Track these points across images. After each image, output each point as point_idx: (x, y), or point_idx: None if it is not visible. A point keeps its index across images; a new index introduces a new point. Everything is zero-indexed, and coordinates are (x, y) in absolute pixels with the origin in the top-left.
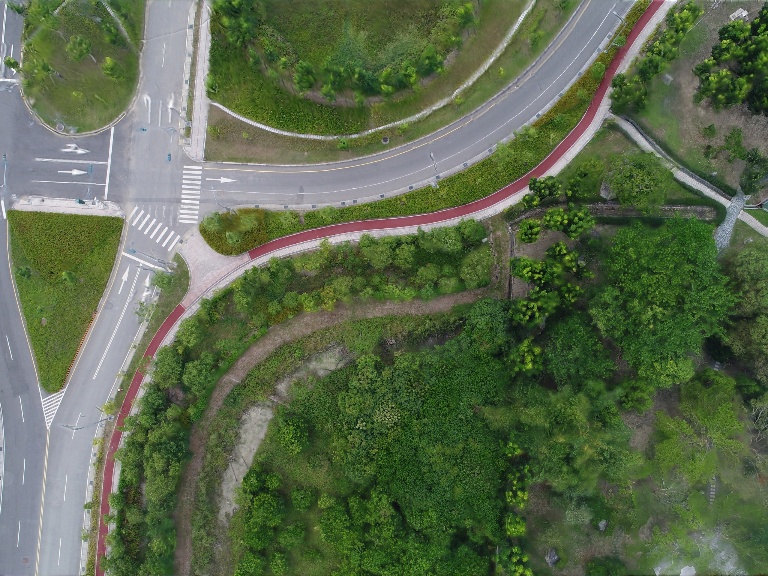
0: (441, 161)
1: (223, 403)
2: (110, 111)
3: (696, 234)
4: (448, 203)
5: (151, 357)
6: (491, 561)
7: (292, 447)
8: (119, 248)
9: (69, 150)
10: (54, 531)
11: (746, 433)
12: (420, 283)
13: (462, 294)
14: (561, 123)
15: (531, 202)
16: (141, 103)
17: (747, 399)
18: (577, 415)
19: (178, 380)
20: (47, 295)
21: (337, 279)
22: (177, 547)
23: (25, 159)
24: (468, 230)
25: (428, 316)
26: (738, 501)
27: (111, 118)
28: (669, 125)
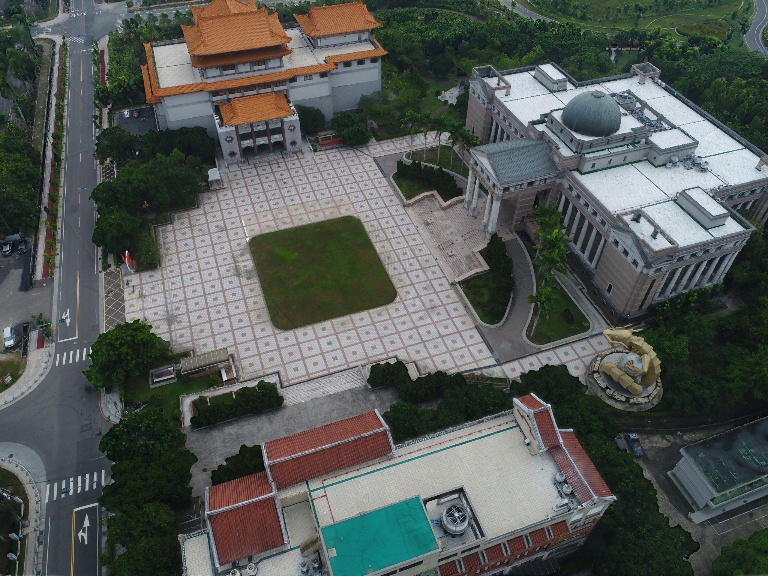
0: None
1: (427, 9)
2: None
3: None
4: None
5: None
6: None
7: None
8: None
9: None
10: None
11: None
12: None
13: None
14: None
15: None
16: None
17: None
18: None
19: None
20: None
21: None
22: None
23: None
24: None
25: None
26: None
27: None
28: None
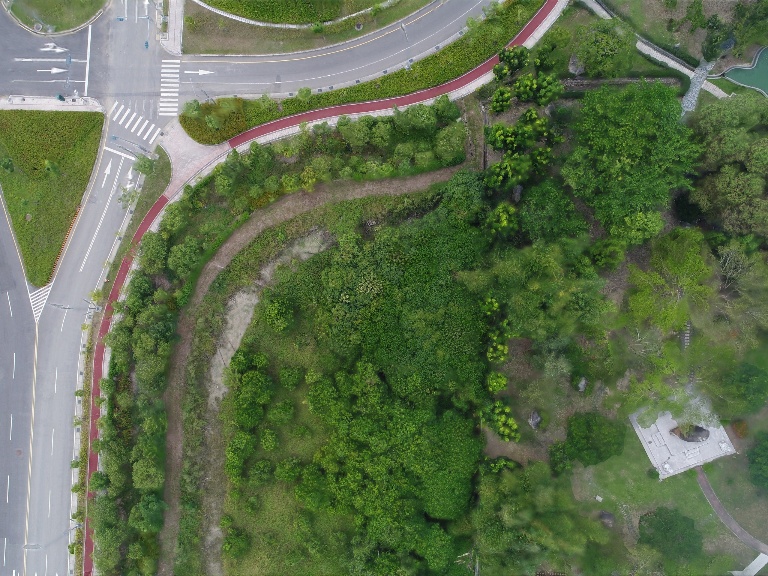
0: (414, 45)
1: (209, 289)
2: (87, 9)
3: (661, 95)
4: (422, 84)
5: None
6: (476, 428)
7: (278, 323)
8: (101, 143)
9: (48, 49)
10: (46, 422)
11: (715, 280)
12: (397, 159)
13: (439, 173)
14: (528, 0)
15: (501, 71)
16: (117, 0)
17: (715, 247)
18: (551, 262)
19: (163, 265)
20: (31, 191)
21: (316, 158)
22: (169, 432)
23: (4, 60)
24: (442, 105)
25: (406, 195)
26: (709, 344)
27: (88, 16)
28: (633, 1)
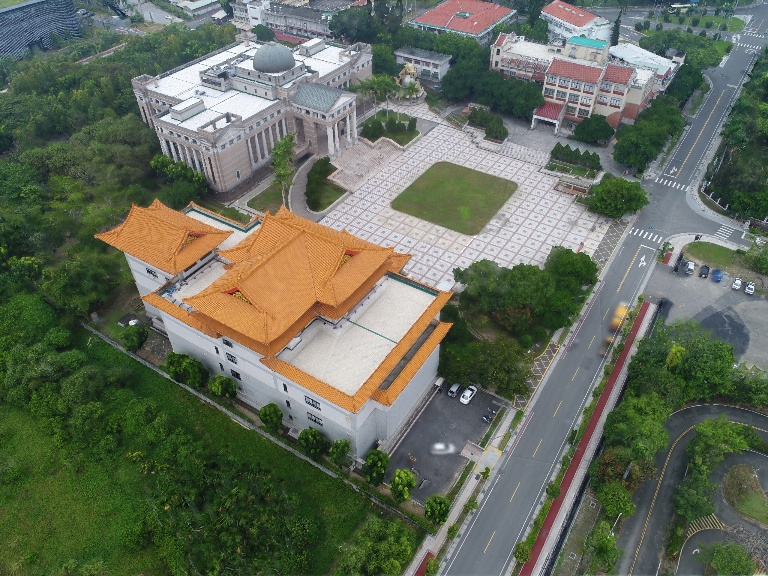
0: None
1: None
2: None
3: None
4: None
5: None
6: None
7: None
8: None
9: None
10: None
11: None
12: None
13: None
14: None
15: None
16: None
17: None
18: None
19: None
20: None
21: None
22: None
23: None
24: None
25: None
26: (97, 190)
27: None
28: None
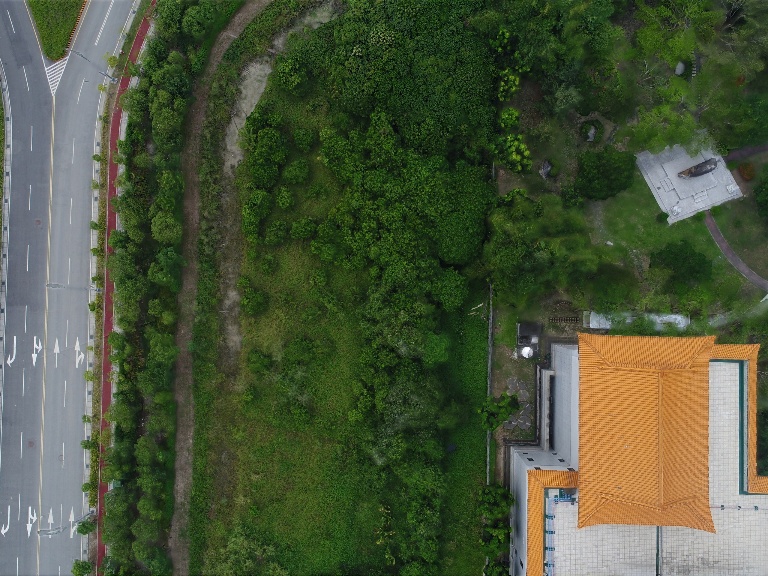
0: None
1: (223, 57)
2: None
3: None
4: None
5: (151, 5)
6: None
7: (292, 79)
8: None
9: None
10: (64, 192)
11: (721, 9)
12: None
13: None
14: None
15: None
16: None
17: None
18: None
19: (178, 29)
20: None
21: None
22: (185, 198)
23: None
24: None
25: None
26: (716, 67)
27: None
28: None
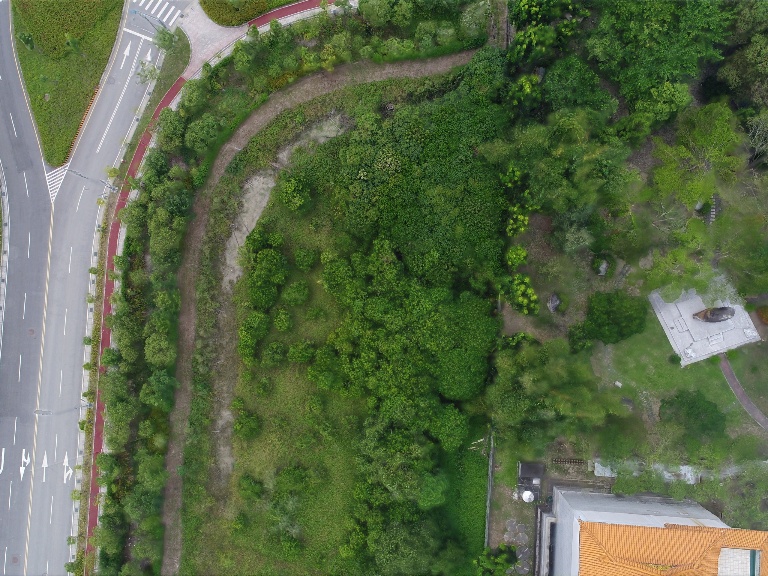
0: None
1: (225, 170)
2: None
3: None
4: None
5: None
6: (493, 313)
7: (294, 200)
8: (120, 24)
9: None
10: (59, 302)
11: (743, 152)
12: (418, 37)
13: (460, 56)
14: None
15: None
16: None
17: (744, 119)
18: (575, 125)
19: (180, 143)
20: (50, 71)
21: None
22: (182, 313)
23: None
24: None
25: (427, 77)
26: (737, 216)
27: None
28: None
